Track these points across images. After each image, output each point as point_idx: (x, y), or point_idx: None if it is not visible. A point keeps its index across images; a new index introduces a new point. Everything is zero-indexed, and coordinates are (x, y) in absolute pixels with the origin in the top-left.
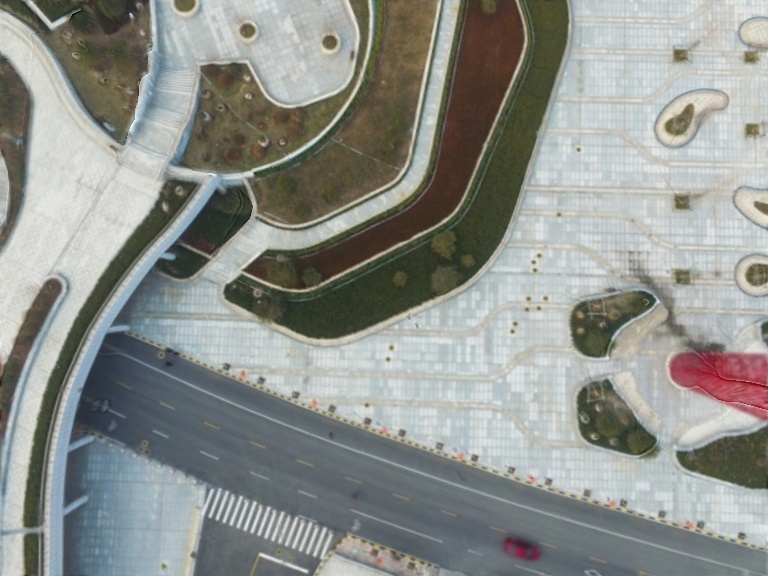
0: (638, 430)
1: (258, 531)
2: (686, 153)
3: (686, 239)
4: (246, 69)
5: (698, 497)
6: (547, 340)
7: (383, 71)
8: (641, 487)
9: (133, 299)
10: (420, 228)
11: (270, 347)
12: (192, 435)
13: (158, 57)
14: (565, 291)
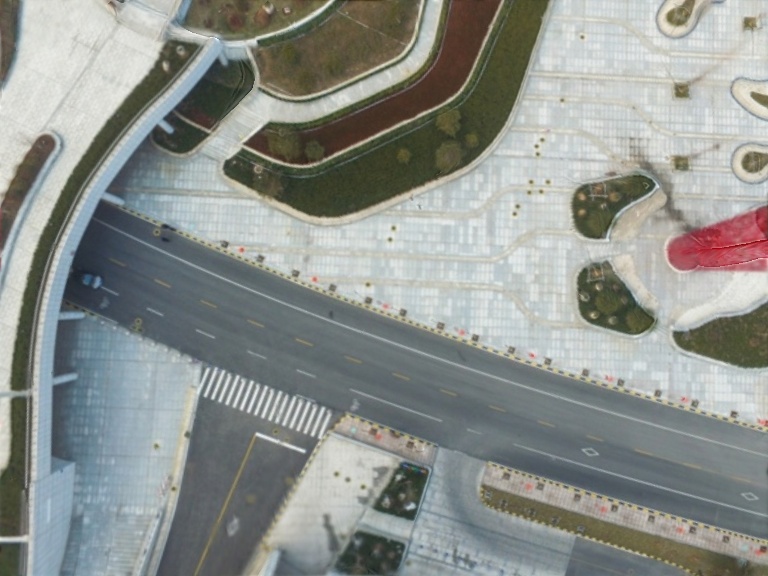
0: (636, 310)
1: (255, 410)
2: (686, 44)
3: (685, 127)
4: None
5: (693, 377)
6: (549, 223)
7: None
8: (638, 367)
9: (129, 165)
10: (425, 106)
11: (270, 225)
12: (188, 313)
13: None
14: (567, 175)
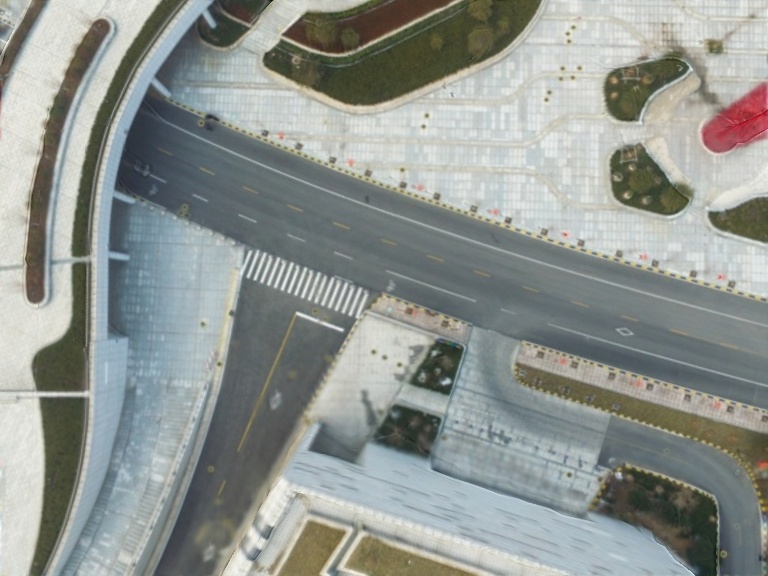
0: (671, 190)
1: (295, 291)
2: None
3: (719, 11)
4: None
5: (729, 257)
6: (580, 108)
7: None
8: (673, 248)
9: (177, 53)
10: None
11: (308, 114)
12: (231, 199)
13: None
14: (599, 61)
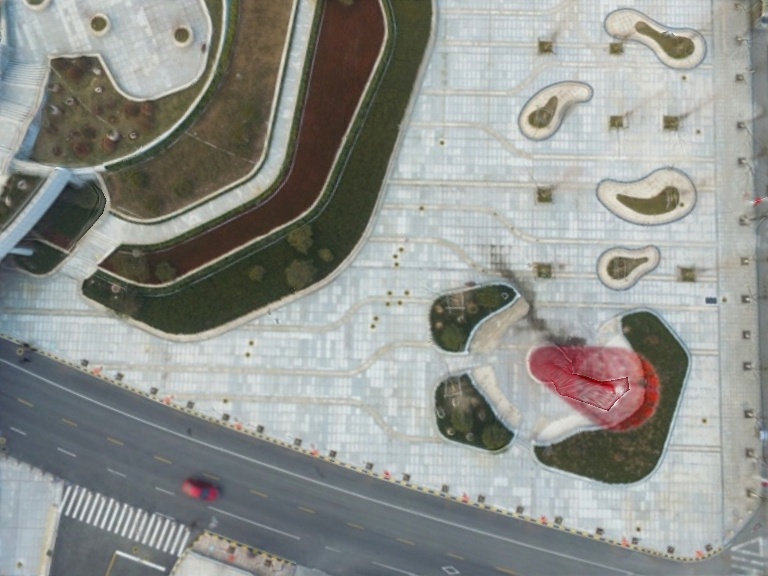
0: (495, 425)
1: (115, 528)
2: (550, 146)
3: (548, 232)
4: (97, 62)
5: (556, 492)
6: (407, 335)
7: (238, 64)
8: (499, 483)
9: None
10: (278, 222)
11: (129, 343)
12: (50, 432)
13: (8, 50)
14: (426, 285)
